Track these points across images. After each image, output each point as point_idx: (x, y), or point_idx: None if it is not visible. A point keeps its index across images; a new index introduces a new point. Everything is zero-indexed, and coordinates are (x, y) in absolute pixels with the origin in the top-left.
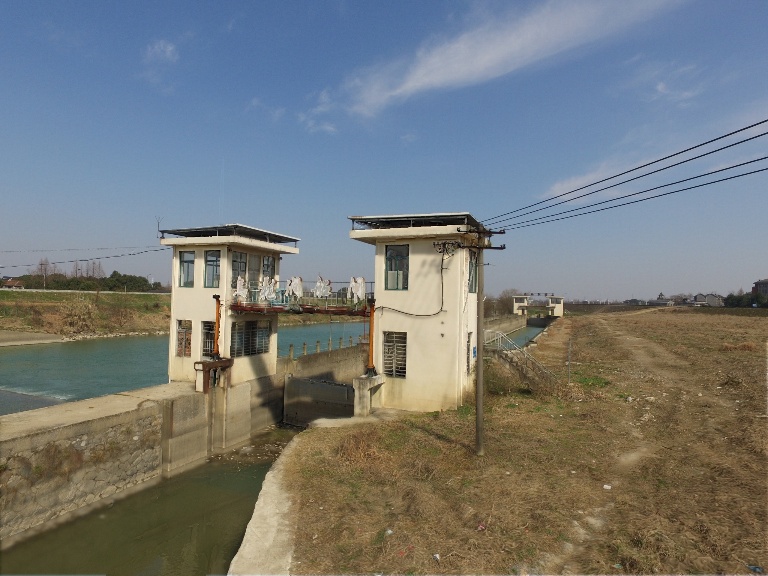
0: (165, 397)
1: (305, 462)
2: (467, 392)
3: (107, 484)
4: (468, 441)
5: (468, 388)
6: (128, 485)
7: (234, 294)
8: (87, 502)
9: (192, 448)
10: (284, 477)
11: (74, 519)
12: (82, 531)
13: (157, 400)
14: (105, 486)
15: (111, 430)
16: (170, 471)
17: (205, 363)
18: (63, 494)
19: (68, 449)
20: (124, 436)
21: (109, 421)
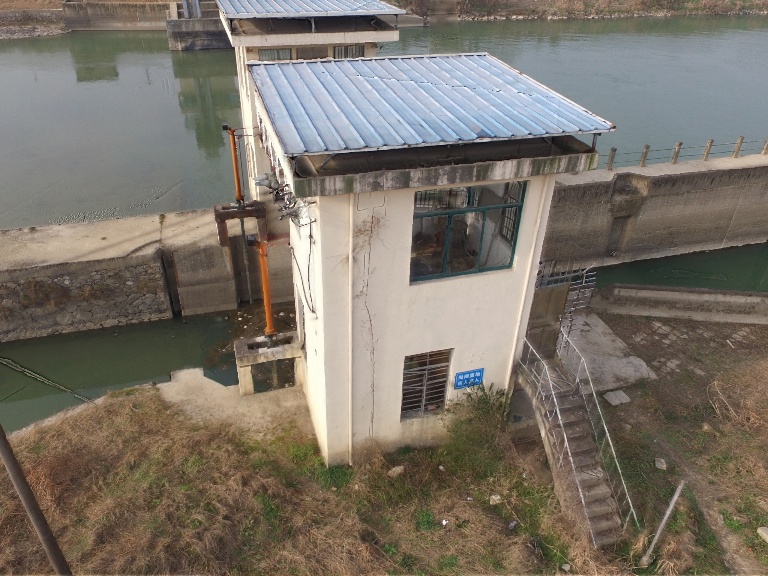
0: (178, 241)
1: None
2: (372, 449)
3: (106, 317)
4: (122, 566)
5: (415, 434)
6: (133, 321)
7: (257, 121)
8: (88, 328)
9: (213, 299)
10: None
11: (79, 338)
12: (91, 347)
13: (165, 244)
14: (104, 318)
15: (96, 273)
16: (185, 316)
17: (215, 213)
18: (60, 318)
19: (52, 285)
20: (114, 280)
21: (90, 266)
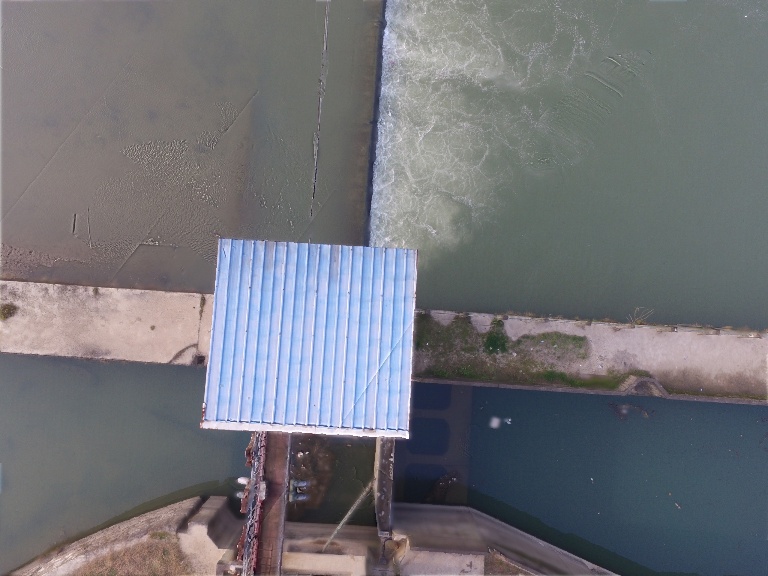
0: None
1: (96, 574)
2: None
3: None
4: None
5: None
6: None
7: None
8: None
9: None
10: (77, 570)
11: None
12: None
13: (200, 352)
14: None
15: None
16: None
17: None
18: None
19: None
20: None
21: None
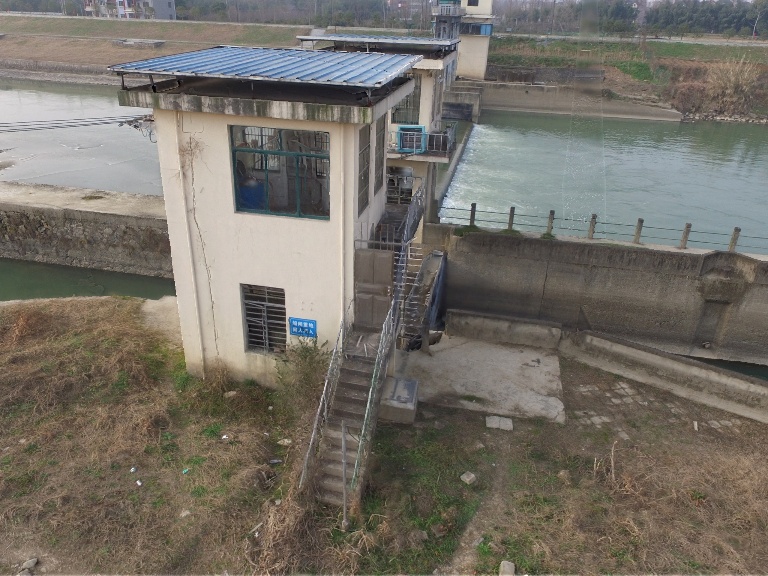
0: None
1: (23, 307)
2: (217, 368)
3: None
4: (6, 376)
5: (260, 371)
6: None
7: None
8: None
9: None
10: (2, 306)
11: None
12: None
13: None
14: None
15: None
16: None
17: None
18: (164, 264)
19: (162, 236)
20: None
21: None
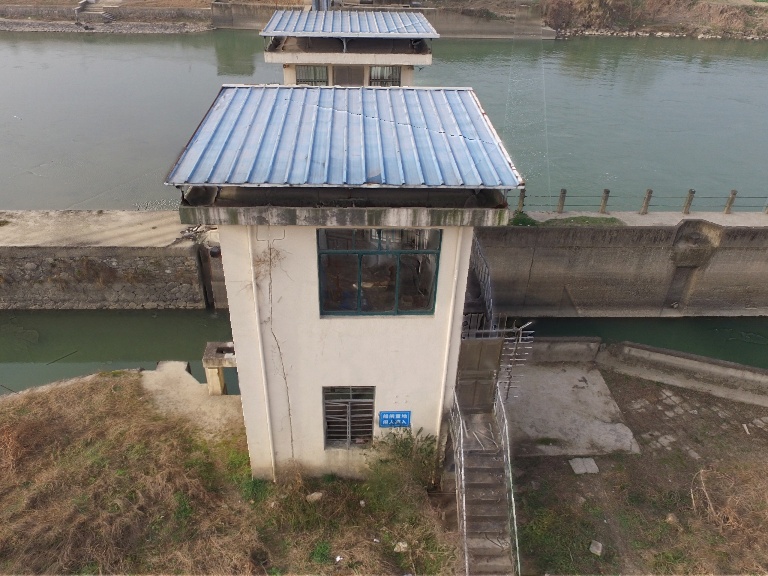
0: None
1: None
2: (293, 470)
3: (147, 299)
4: (38, 532)
5: (341, 464)
6: (170, 306)
7: None
8: (131, 307)
9: None
10: None
11: (123, 315)
12: (133, 325)
13: None
14: (146, 300)
15: (140, 259)
16: (217, 309)
17: None
18: (108, 295)
19: (102, 265)
20: (155, 267)
21: (135, 251)
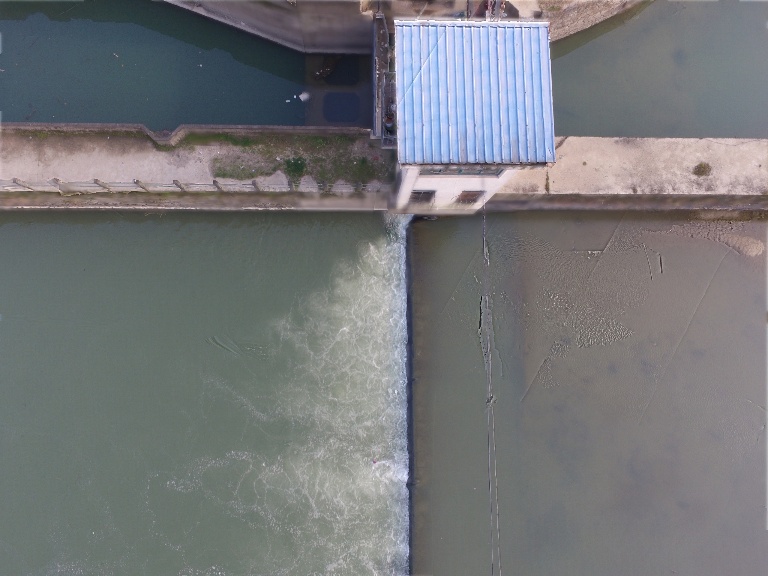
0: None
1: None
2: None
3: None
4: None
5: None
6: None
7: None
8: None
9: None
10: None
11: None
12: None
13: None
14: None
15: None
16: None
17: None
18: None
19: None
20: None
21: None
